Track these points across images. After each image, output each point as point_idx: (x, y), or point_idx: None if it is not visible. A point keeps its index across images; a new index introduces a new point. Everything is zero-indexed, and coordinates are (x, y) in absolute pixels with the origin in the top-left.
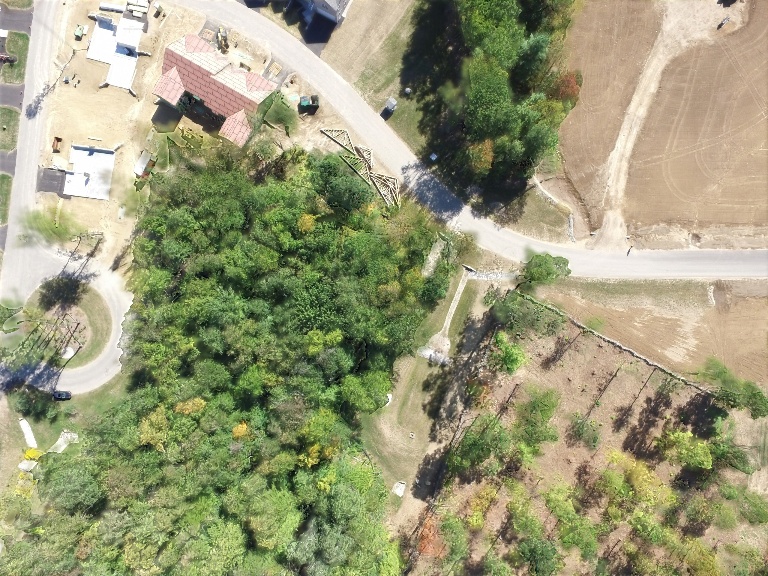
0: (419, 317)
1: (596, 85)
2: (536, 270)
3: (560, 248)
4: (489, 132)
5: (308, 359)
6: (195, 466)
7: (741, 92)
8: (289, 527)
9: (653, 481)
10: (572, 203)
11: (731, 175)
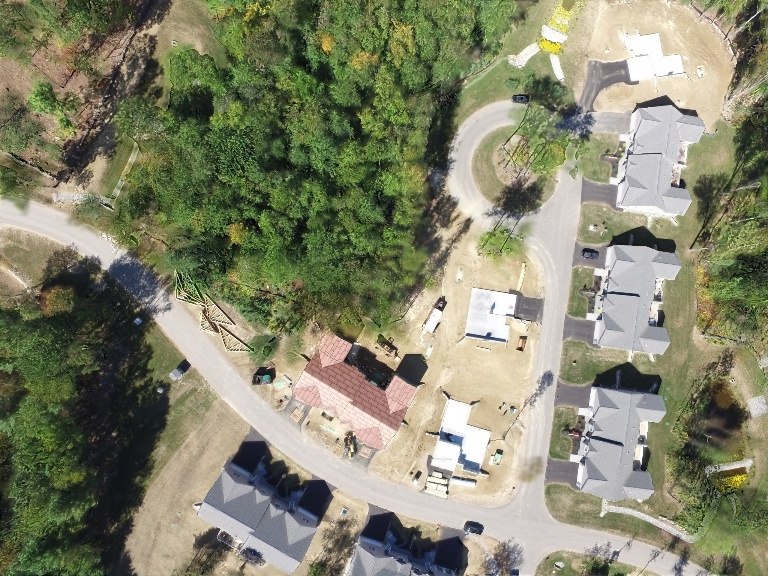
0: None
1: None
2: None
3: (9, 223)
4: (47, 324)
5: (249, 103)
6: (364, 5)
7: None
8: None
9: None
10: None
11: None
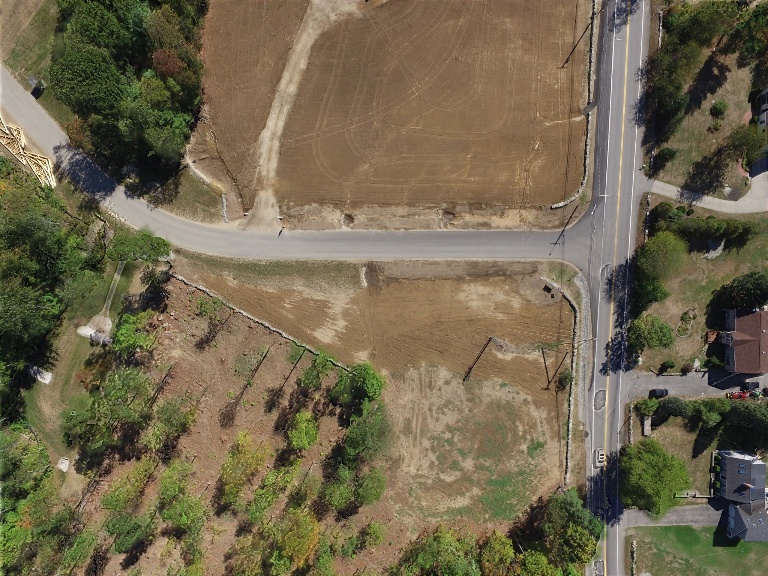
0: None
1: (246, 61)
2: None
3: (212, 229)
4: (80, 110)
5: None
6: None
7: (391, 68)
8: None
9: (304, 460)
10: (226, 183)
11: (383, 154)
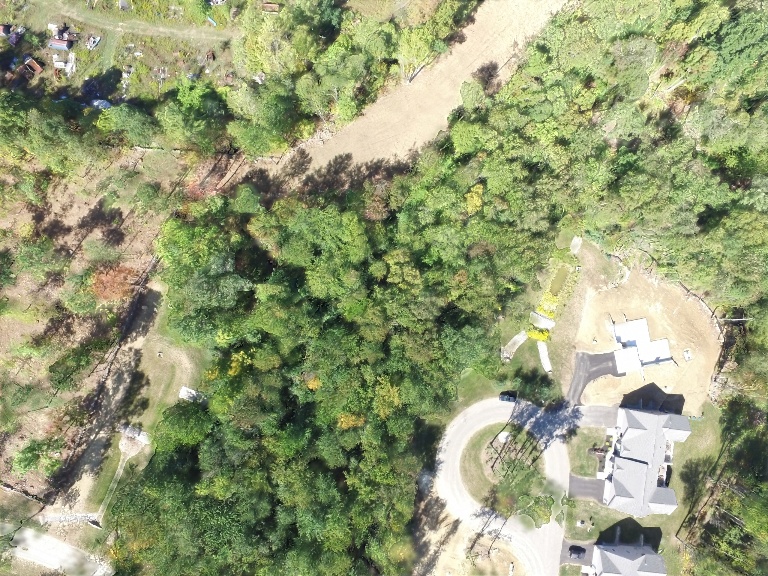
0: None
1: None
2: None
3: None
4: None
5: (234, 467)
6: None
7: None
8: None
9: None
10: None
11: None
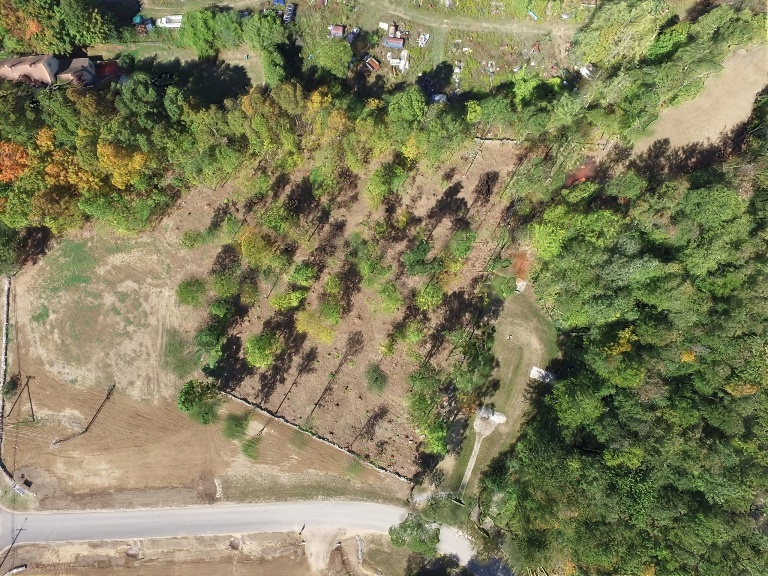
0: None
1: None
2: None
3: (372, 529)
4: None
5: (637, 437)
6: None
7: None
8: (646, 273)
9: None
10: (359, 573)
11: None
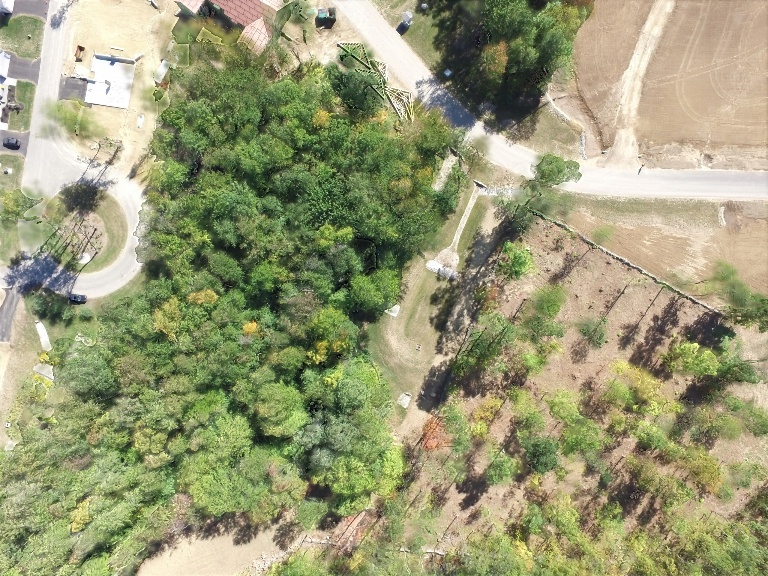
0: (429, 227)
1: (612, 4)
2: (547, 167)
3: None
4: (504, 34)
5: (319, 255)
6: (206, 356)
7: (758, 13)
8: (296, 421)
9: (658, 399)
10: (584, 121)
11: (745, 96)
